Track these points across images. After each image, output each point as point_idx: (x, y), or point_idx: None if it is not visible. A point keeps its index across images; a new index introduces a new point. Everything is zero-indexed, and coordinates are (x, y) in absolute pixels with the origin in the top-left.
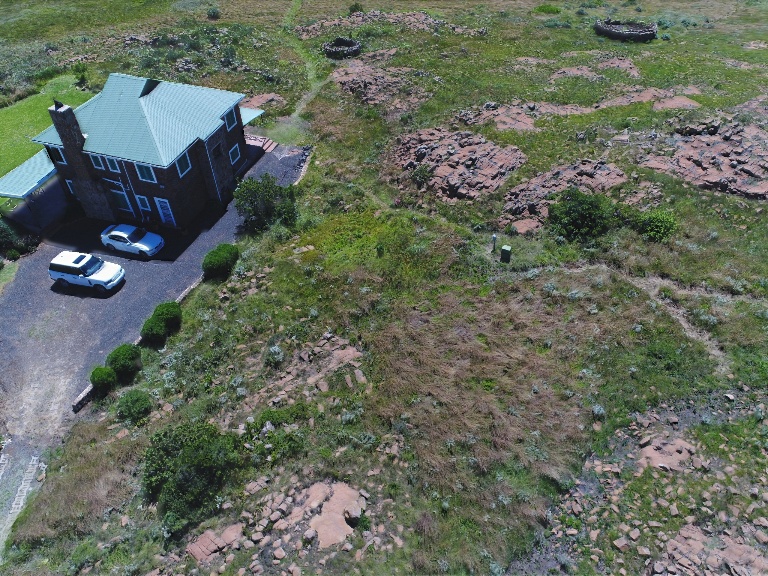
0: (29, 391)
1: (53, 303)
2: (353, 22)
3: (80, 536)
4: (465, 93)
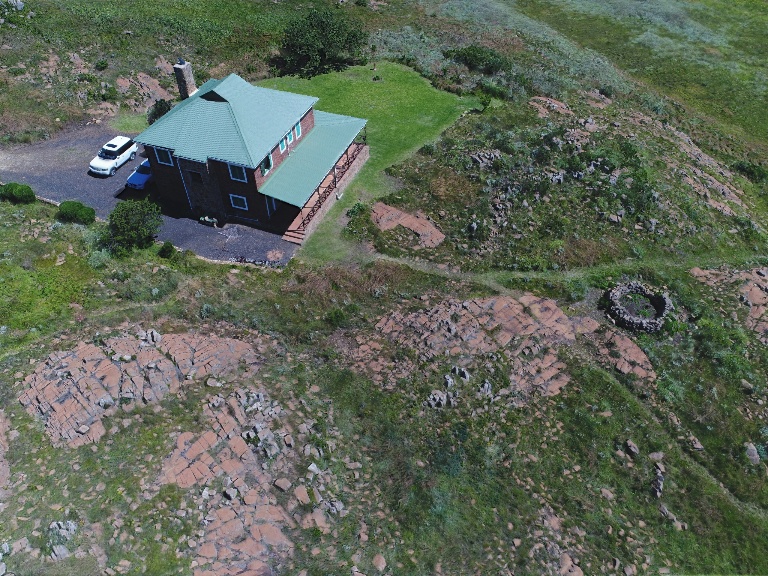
0: (4, 156)
1: None
2: (761, 319)
3: None
4: (395, 437)
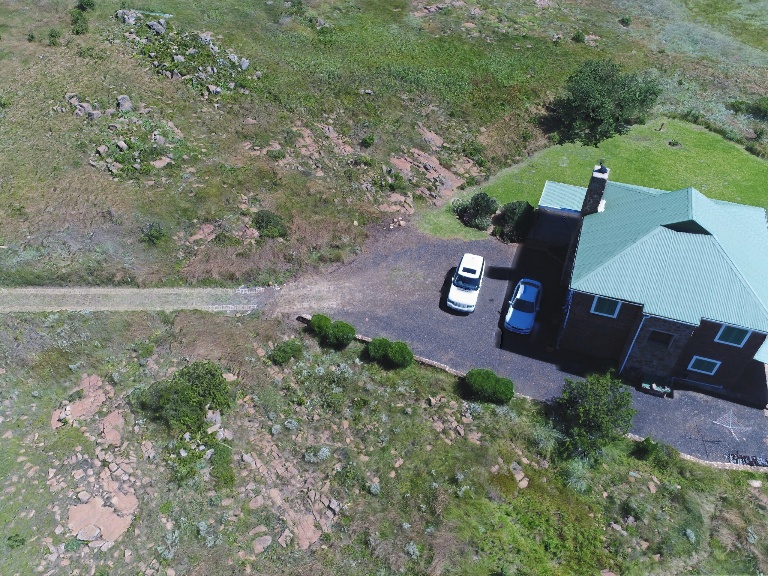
0: (326, 286)
1: (433, 273)
2: None
3: (170, 347)
4: None
